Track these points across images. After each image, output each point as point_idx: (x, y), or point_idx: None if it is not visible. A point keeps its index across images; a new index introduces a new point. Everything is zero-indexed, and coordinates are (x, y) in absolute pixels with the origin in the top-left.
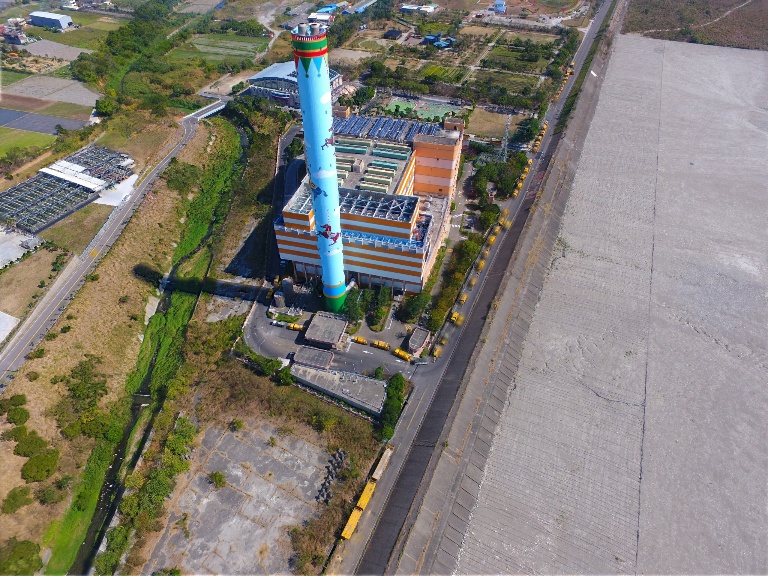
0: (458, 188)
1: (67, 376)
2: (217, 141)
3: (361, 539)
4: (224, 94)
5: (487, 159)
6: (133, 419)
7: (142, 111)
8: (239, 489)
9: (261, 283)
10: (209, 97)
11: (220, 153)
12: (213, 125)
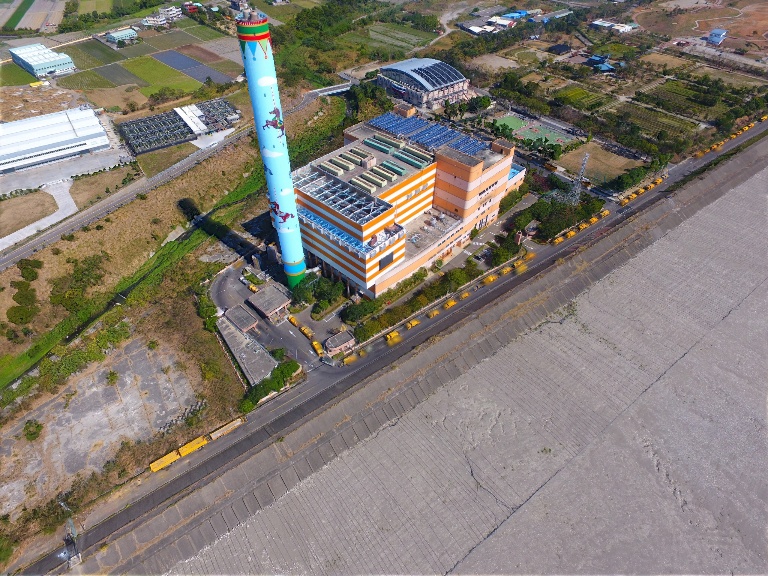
0: (502, 217)
1: (80, 261)
2: (322, 117)
3: (165, 477)
4: (358, 78)
5: (557, 197)
6: (104, 311)
7: (279, 79)
8: (119, 393)
9: (259, 244)
10: (344, 78)
11: (315, 128)
12: (330, 103)
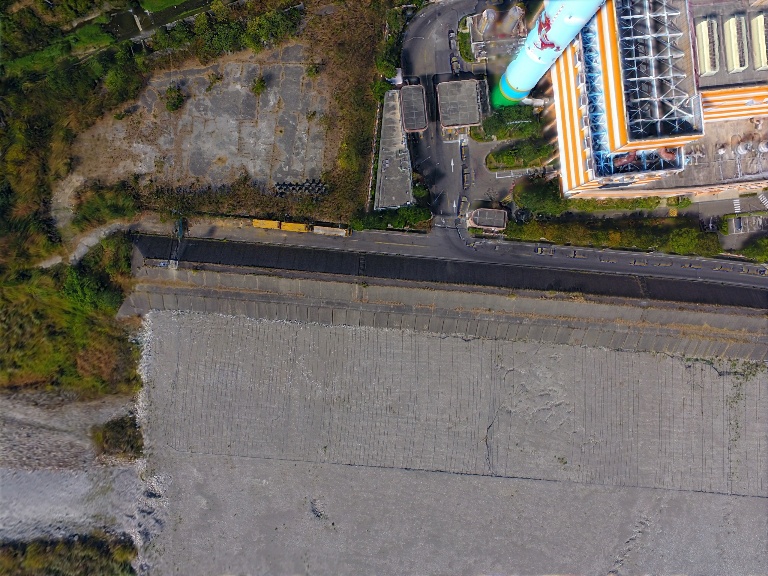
0: None
1: None
2: None
3: (261, 237)
4: None
5: None
6: None
7: None
8: (259, 111)
9: None
10: None
11: None
12: None
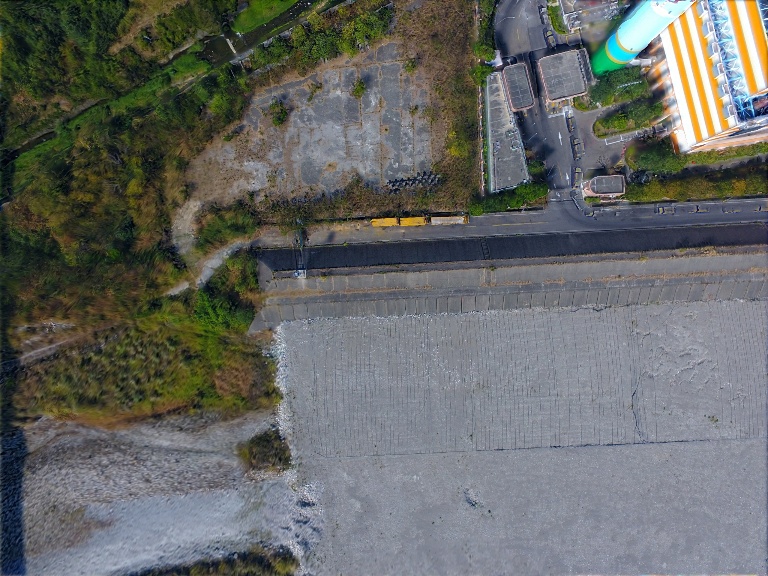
0: None
1: None
2: None
3: (380, 235)
4: None
5: None
6: None
7: None
8: (361, 113)
9: None
10: None
11: None
12: None
